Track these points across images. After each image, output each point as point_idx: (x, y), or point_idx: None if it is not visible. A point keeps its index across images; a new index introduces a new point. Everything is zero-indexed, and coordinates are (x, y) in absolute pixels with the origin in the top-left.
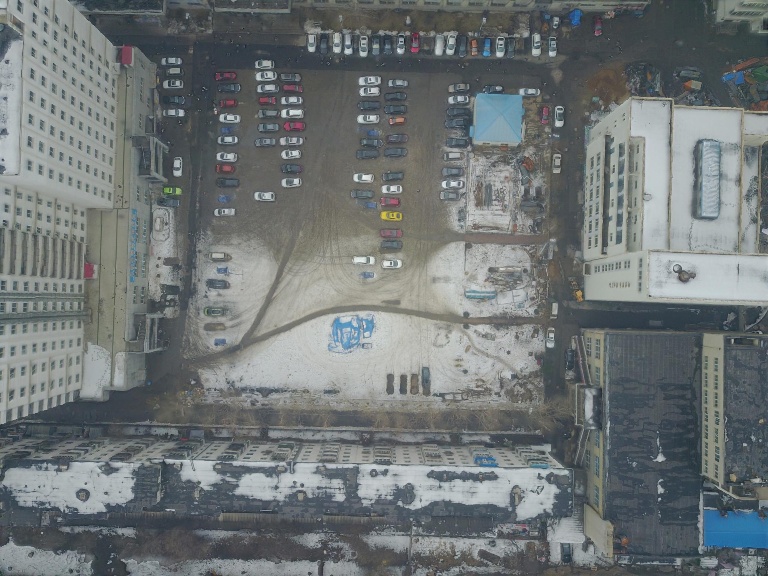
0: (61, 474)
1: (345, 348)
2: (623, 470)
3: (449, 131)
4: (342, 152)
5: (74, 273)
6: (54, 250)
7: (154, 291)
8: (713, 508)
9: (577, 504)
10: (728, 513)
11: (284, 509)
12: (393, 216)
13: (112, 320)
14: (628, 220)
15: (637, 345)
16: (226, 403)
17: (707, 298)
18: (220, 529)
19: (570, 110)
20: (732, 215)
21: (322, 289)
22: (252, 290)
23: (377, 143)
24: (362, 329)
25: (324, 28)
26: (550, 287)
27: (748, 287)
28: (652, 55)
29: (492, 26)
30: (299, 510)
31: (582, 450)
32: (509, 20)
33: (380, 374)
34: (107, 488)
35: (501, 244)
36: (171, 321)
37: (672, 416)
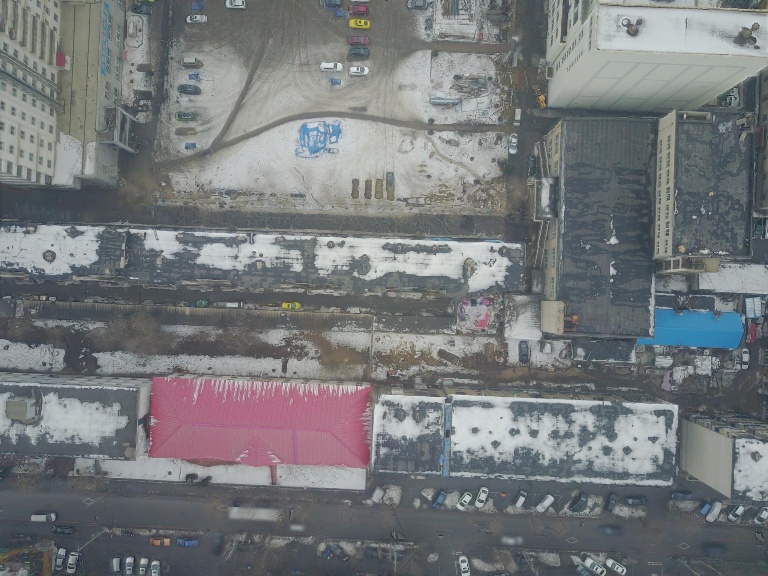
0: (29, 236)
1: (312, 152)
2: (577, 253)
3: None
4: None
5: (45, 54)
6: (24, 18)
7: (127, 96)
8: (669, 308)
9: (535, 302)
10: (683, 312)
11: (243, 278)
12: (360, 23)
13: (84, 111)
14: (585, 1)
15: (593, 131)
16: (195, 205)
17: (655, 51)
18: (187, 323)
19: None
20: None
21: (290, 95)
22: (222, 96)
23: None
24: (329, 134)
25: None
26: (514, 95)
27: (696, 41)
28: None
29: None
30: (258, 279)
31: (541, 251)
32: None
33: (345, 179)
34: (73, 250)
35: (467, 53)
36: (143, 125)
37: (626, 200)
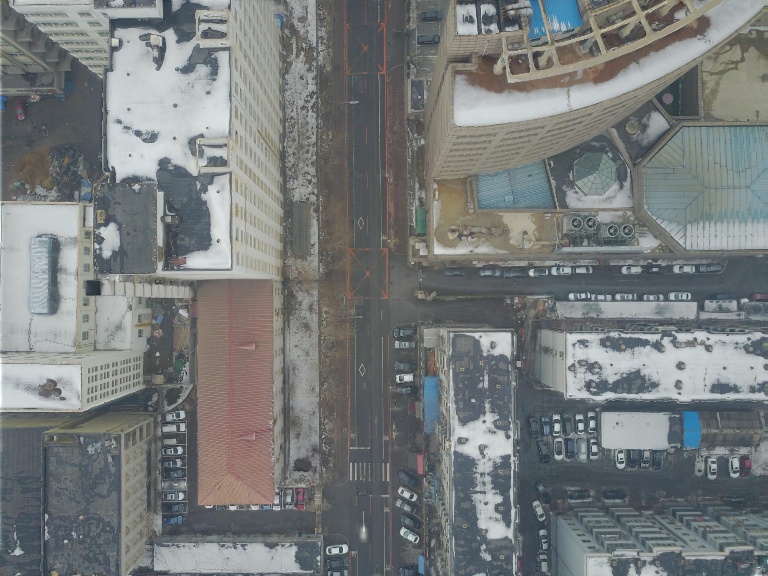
0: None
1: None
2: None
3: None
4: None
5: None
6: None
7: None
8: None
9: None
10: None
11: None
12: None
13: None
14: None
15: None
16: None
17: None
18: None
19: None
20: (71, 309)
21: None
22: None
23: None
24: None
25: None
26: None
27: (1, 395)
28: (77, 138)
29: None
30: None
31: None
32: None
33: None
34: None
35: None
36: None
37: (30, 509)
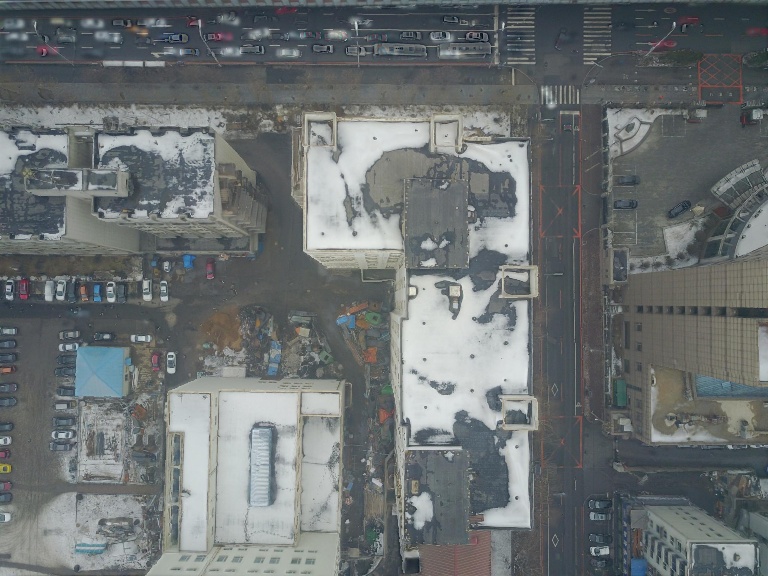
0: None
1: None
2: None
3: (61, 379)
4: None
5: None
6: None
7: None
8: None
9: None
10: None
11: None
12: None
13: None
14: None
15: None
16: None
17: None
18: None
19: (184, 355)
20: (289, 500)
21: None
22: None
23: None
24: None
25: None
26: None
27: None
28: (267, 298)
29: (105, 270)
30: None
31: None
32: (122, 263)
33: None
34: None
35: (113, 494)
36: None
37: None
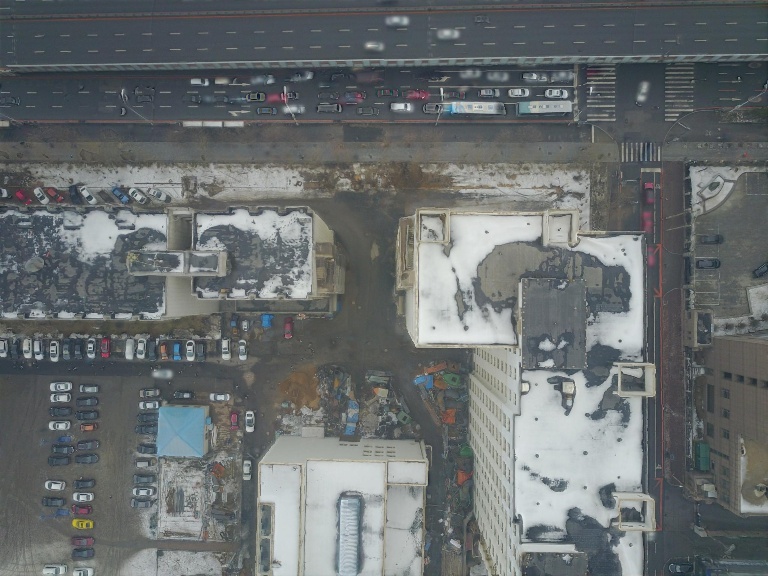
0: None
1: None
2: None
3: (141, 436)
4: (35, 458)
5: None
6: None
7: None
8: None
9: None
10: None
11: None
12: (82, 526)
13: None
14: None
15: None
16: None
17: None
18: None
19: (262, 413)
20: (376, 569)
21: None
22: None
23: (67, 450)
24: None
25: (16, 332)
26: None
27: None
28: (344, 357)
29: (184, 328)
30: None
31: None
32: (201, 322)
33: None
34: None
35: (193, 551)
36: None
37: None
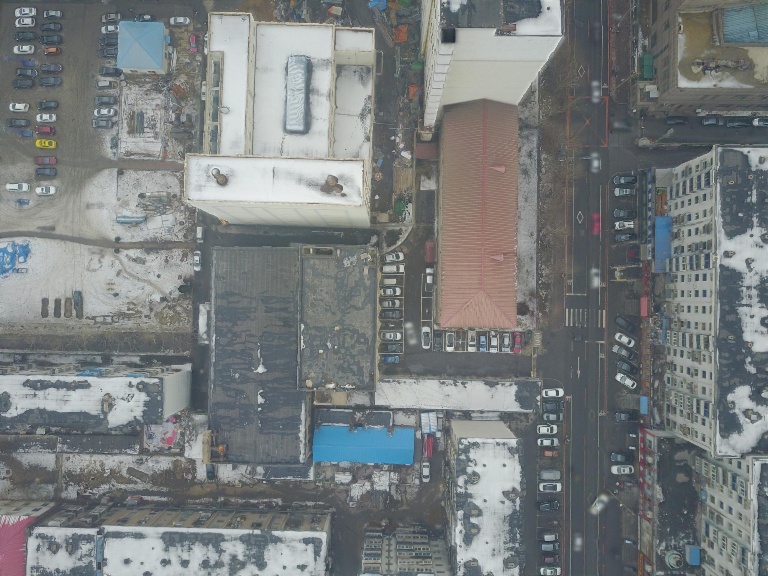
0: None
1: None
2: (227, 381)
3: (103, 60)
4: None
5: None
6: None
7: None
8: (345, 424)
9: None
10: (358, 429)
11: None
12: (45, 143)
13: None
14: None
15: (241, 260)
16: None
17: (243, 200)
18: None
19: None
20: (323, 129)
21: None
22: None
23: (31, 73)
24: (17, 254)
25: None
26: (199, 212)
27: (283, 190)
28: None
29: None
30: None
31: None
32: None
33: (35, 298)
34: None
35: (152, 170)
36: None
37: (274, 328)
